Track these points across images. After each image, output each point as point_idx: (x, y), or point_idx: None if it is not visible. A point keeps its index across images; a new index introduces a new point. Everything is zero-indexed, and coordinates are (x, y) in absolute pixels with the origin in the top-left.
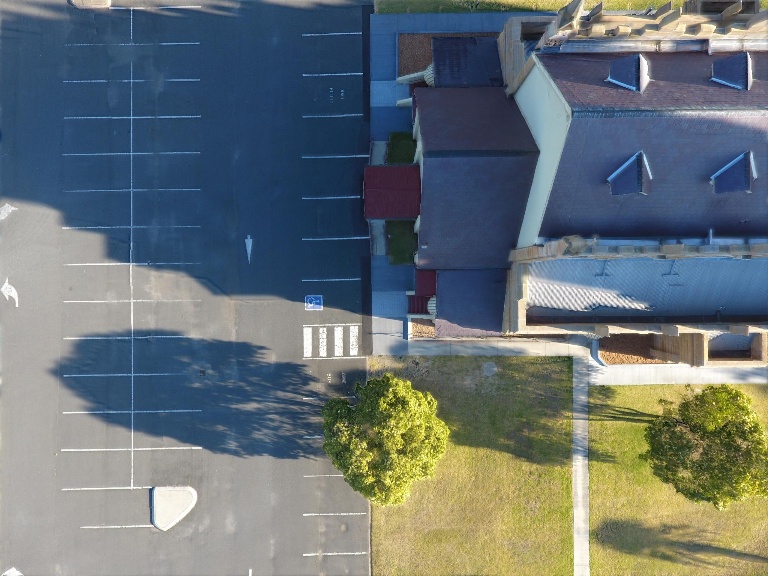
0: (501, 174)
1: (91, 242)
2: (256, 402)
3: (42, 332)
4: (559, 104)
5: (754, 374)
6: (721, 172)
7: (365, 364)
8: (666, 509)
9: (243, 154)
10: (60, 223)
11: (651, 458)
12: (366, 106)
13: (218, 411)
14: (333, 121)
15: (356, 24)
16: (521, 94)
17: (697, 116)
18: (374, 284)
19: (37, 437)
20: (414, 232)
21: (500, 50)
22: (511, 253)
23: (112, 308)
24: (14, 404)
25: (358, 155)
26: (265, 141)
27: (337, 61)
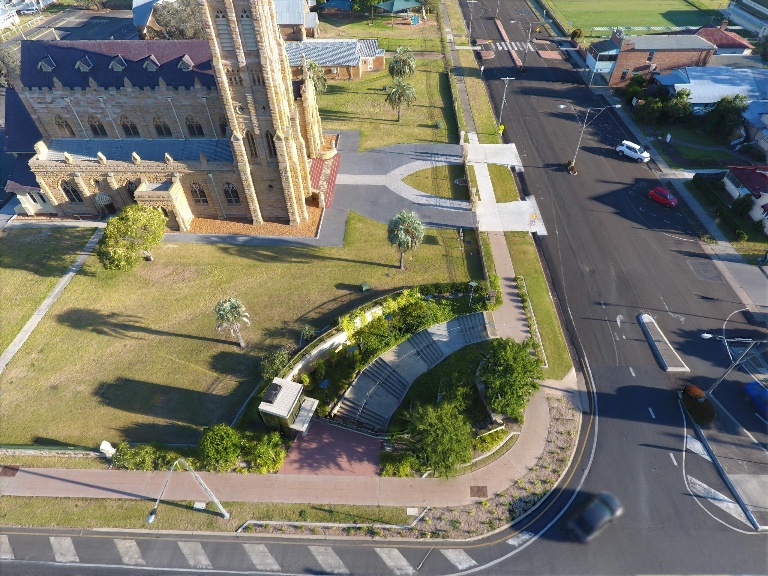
0: None
1: None
2: None
3: None
4: None
5: (209, 239)
6: None
7: None
8: (113, 302)
9: None
10: None
11: None
12: None
13: None
14: None
15: None
16: None
17: (61, 42)
18: (10, 202)
19: None
20: None
21: None
22: None
23: None
24: None
25: None
26: None
27: None
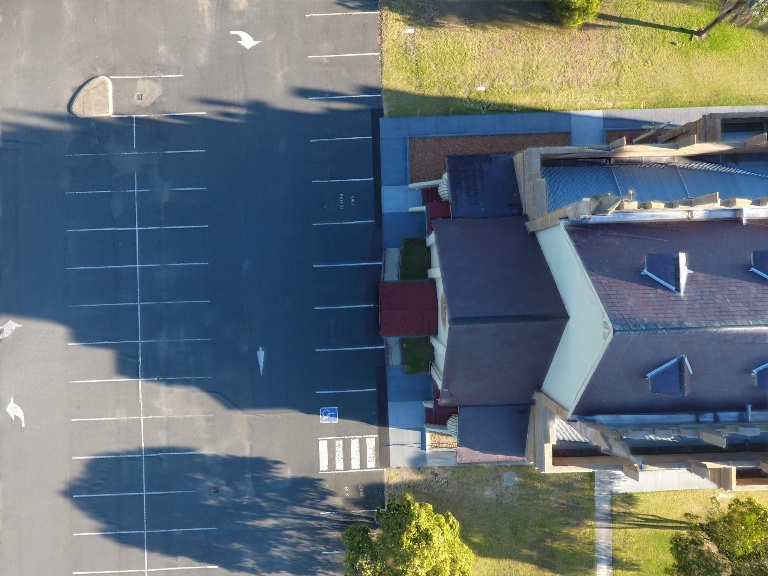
0: (528, 335)
1: (98, 358)
2: (272, 518)
3: (50, 452)
4: (594, 296)
5: None
6: (764, 367)
7: (383, 476)
8: None
9: (253, 264)
10: (66, 339)
11: (678, 574)
12: (378, 212)
13: (233, 528)
14: (344, 228)
15: (365, 128)
16: (544, 239)
17: (743, 331)
18: (390, 394)
19: (47, 560)
20: (430, 342)
21: (517, 171)
22: (536, 395)
23: (122, 425)
24: (23, 527)
25: (371, 262)
26: (275, 250)
27: (347, 166)
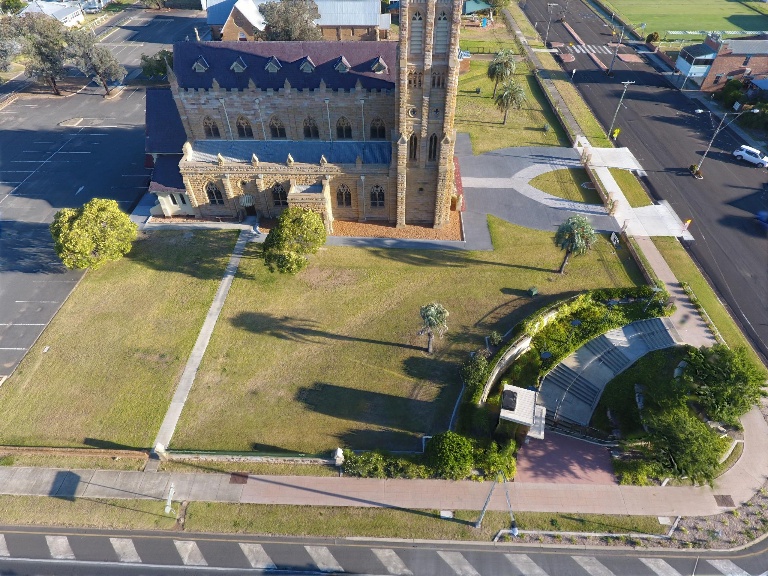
0: None
1: None
2: (32, 247)
3: None
4: None
5: (356, 242)
6: None
7: None
8: (282, 306)
9: (102, 163)
10: None
11: None
12: None
13: (4, 250)
14: None
15: None
16: None
17: (215, 43)
18: (140, 203)
19: None
20: None
21: None
22: None
23: None
24: None
25: None
26: (117, 159)
27: None
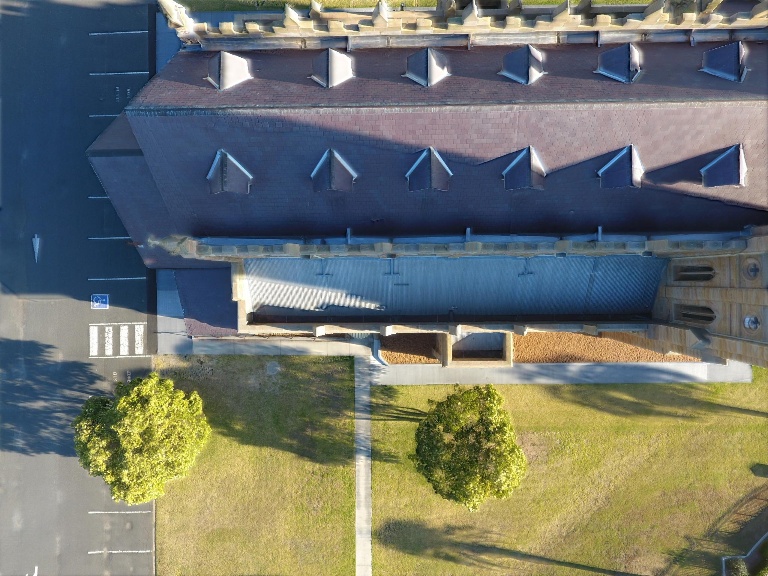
0: None
1: None
2: (43, 400)
3: None
4: None
5: (540, 374)
6: (316, 170)
7: (150, 363)
8: (450, 510)
9: (31, 153)
10: None
11: (416, 458)
12: None
13: (6, 409)
14: None
15: (142, 23)
16: None
17: (251, 114)
18: (159, 283)
19: None
20: None
21: None
22: None
23: None
24: None
25: None
26: (52, 140)
27: (123, 60)
